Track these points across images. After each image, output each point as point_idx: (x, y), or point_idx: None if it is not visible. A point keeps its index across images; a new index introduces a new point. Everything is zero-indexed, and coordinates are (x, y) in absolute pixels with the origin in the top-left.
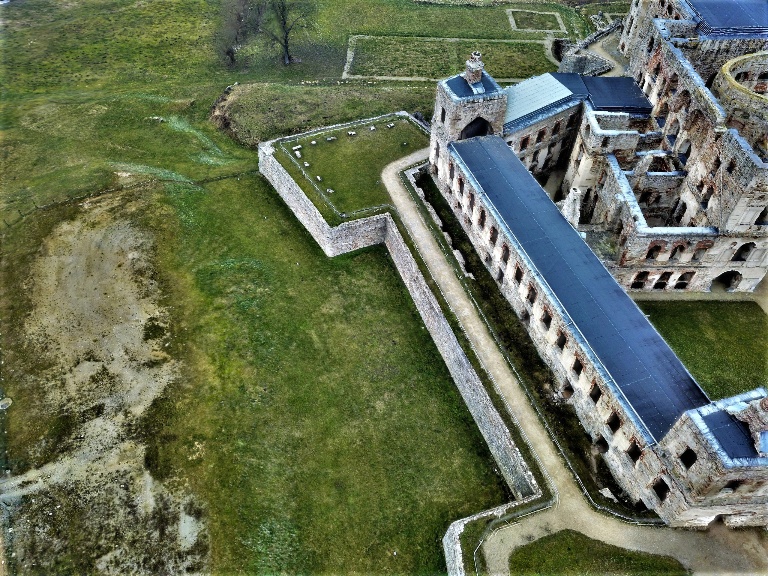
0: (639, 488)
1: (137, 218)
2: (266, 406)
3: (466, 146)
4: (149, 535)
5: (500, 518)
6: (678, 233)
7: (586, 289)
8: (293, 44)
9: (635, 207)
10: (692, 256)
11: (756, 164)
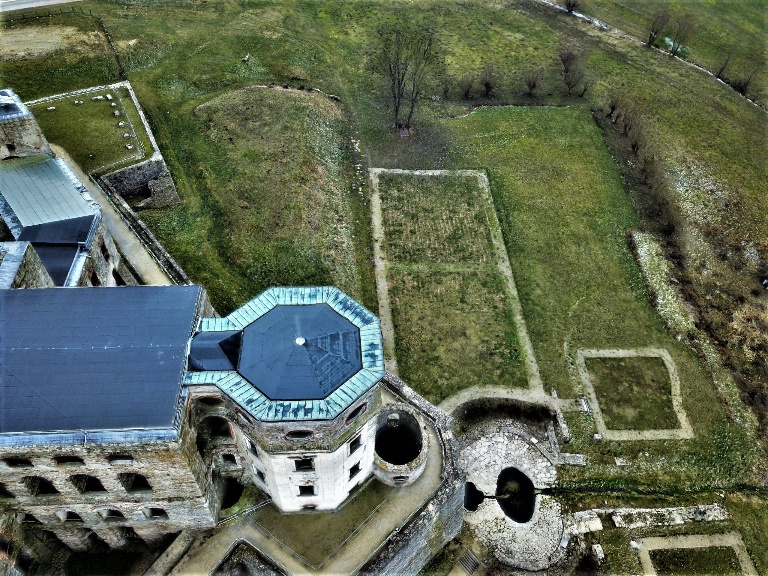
0: None
1: (65, 51)
2: None
3: None
4: None
5: None
6: None
7: None
8: (445, 129)
9: None
10: None
11: None
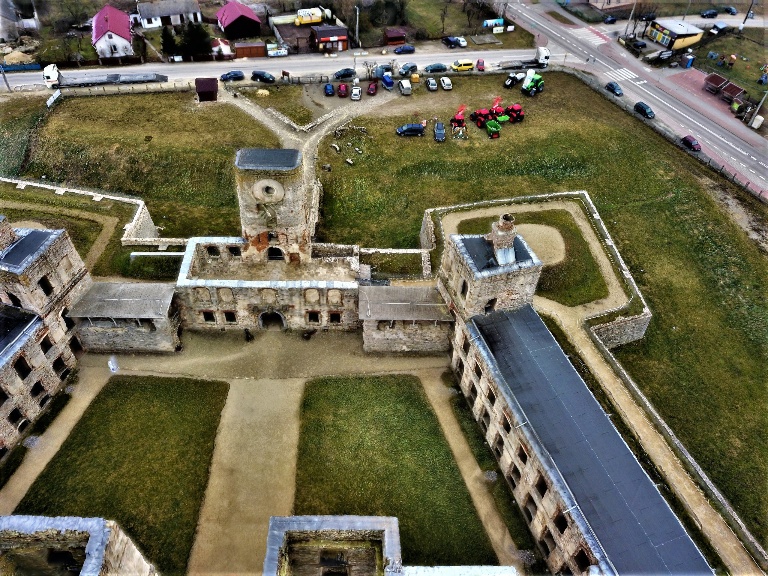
0: None
1: None
2: None
3: None
4: None
5: (619, 315)
6: None
7: (594, 451)
8: None
9: None
10: None
11: None
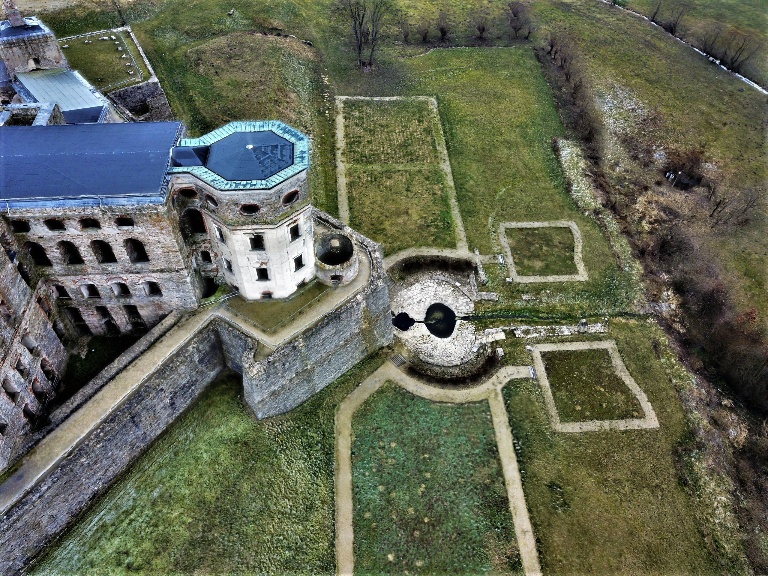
0: None
1: (75, 7)
2: None
3: (3, 64)
4: None
5: None
6: None
7: None
8: (403, 66)
9: None
10: None
11: None
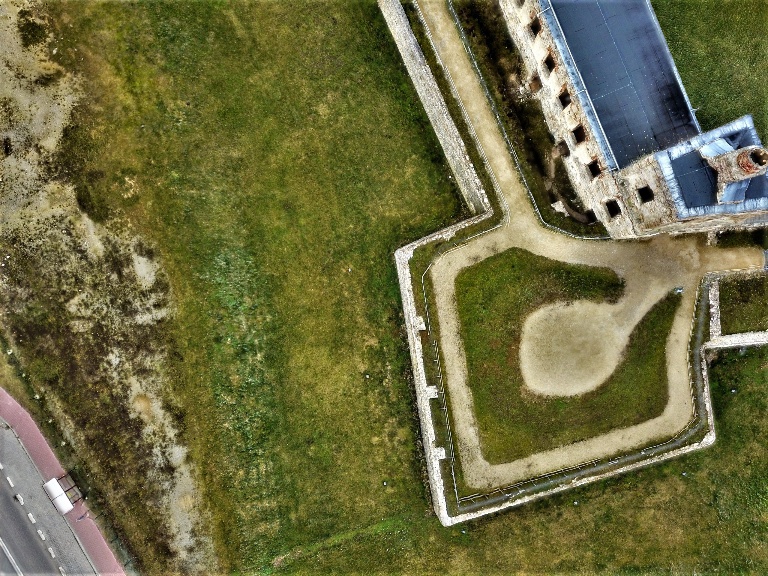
0: (593, 200)
1: None
2: (194, 125)
3: None
4: (108, 278)
5: (449, 241)
6: None
7: None
8: None
9: None
10: None
11: None
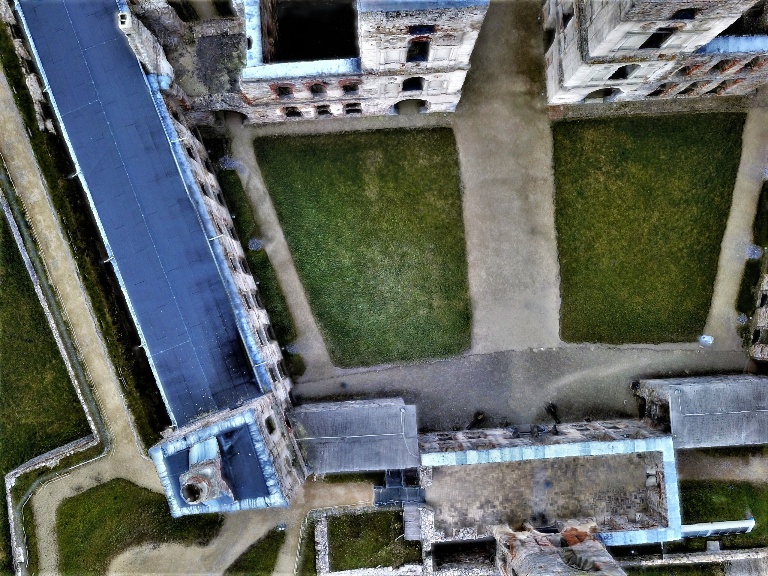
0: None
1: None
2: None
3: None
4: None
5: (52, 470)
6: (301, 75)
7: (137, 202)
8: None
9: (252, 18)
10: (344, 91)
11: (360, 2)
